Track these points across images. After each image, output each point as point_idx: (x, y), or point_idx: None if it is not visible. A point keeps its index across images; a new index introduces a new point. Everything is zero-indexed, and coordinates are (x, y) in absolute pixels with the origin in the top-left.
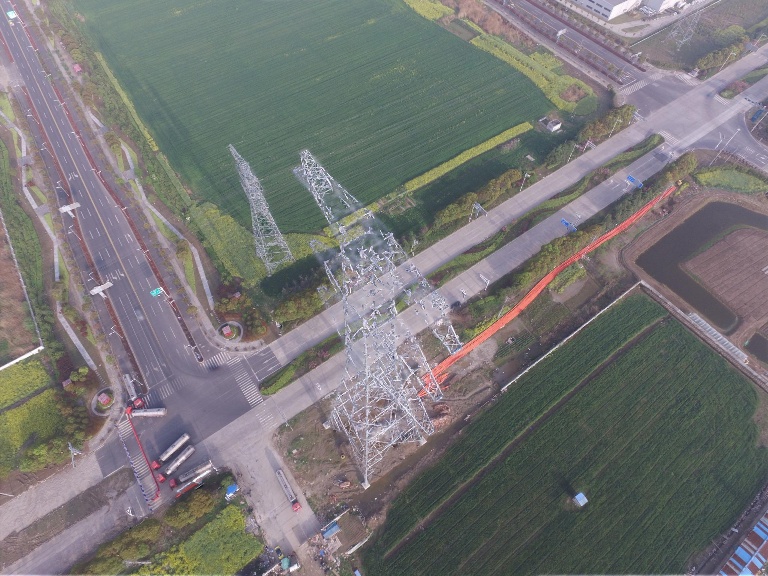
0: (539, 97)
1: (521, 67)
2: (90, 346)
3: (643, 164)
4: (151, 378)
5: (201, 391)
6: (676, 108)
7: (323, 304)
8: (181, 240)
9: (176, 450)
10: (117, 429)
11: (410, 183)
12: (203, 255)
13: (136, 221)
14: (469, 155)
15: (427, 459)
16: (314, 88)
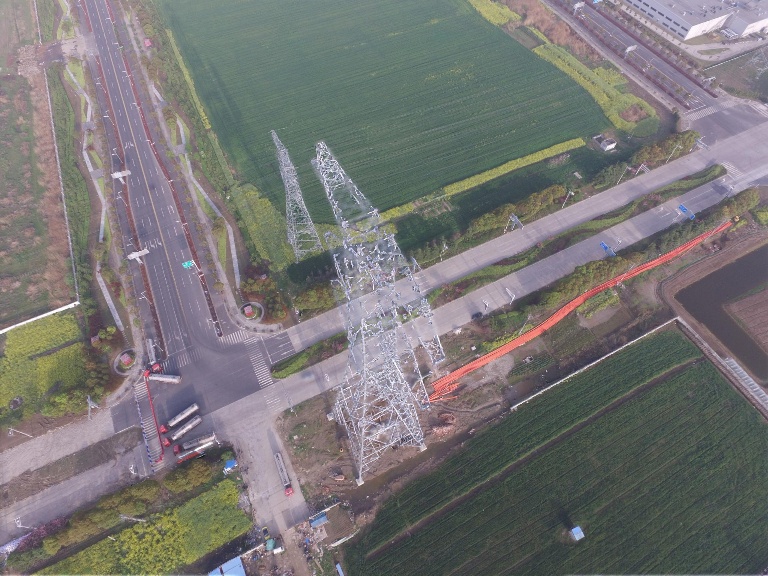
0: (597, 113)
1: (582, 81)
2: (121, 307)
3: (699, 195)
4: (172, 346)
5: (216, 365)
6: (745, 139)
7: (344, 297)
8: (218, 217)
9: (184, 418)
10: (134, 389)
11: (449, 187)
12: (237, 234)
13: (180, 194)
14: (514, 165)
15: (425, 466)
16: (368, 83)
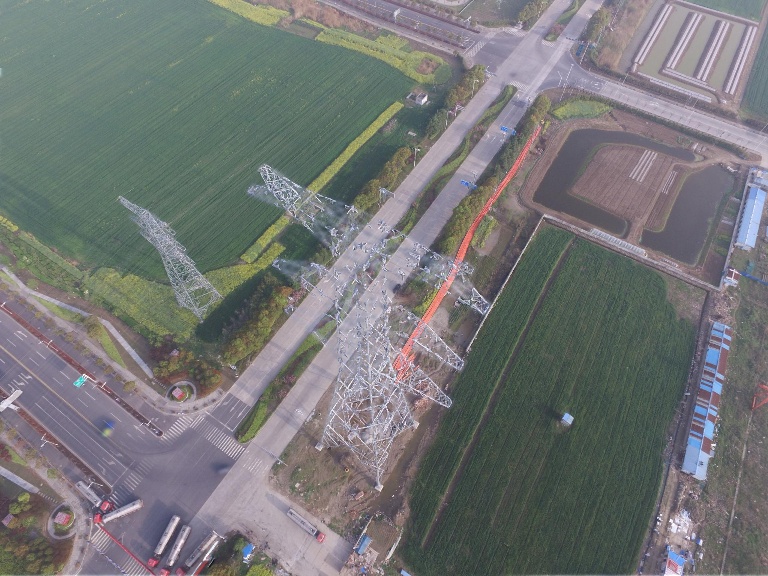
0: (399, 76)
1: (372, 52)
2: (20, 469)
3: (508, 114)
4: (110, 475)
5: (173, 466)
6: (516, 59)
7: (270, 331)
8: (87, 317)
9: (170, 537)
10: (91, 544)
11: (310, 187)
12: (118, 325)
13: (22, 314)
14: (356, 146)
15: (426, 439)
16: (175, 119)
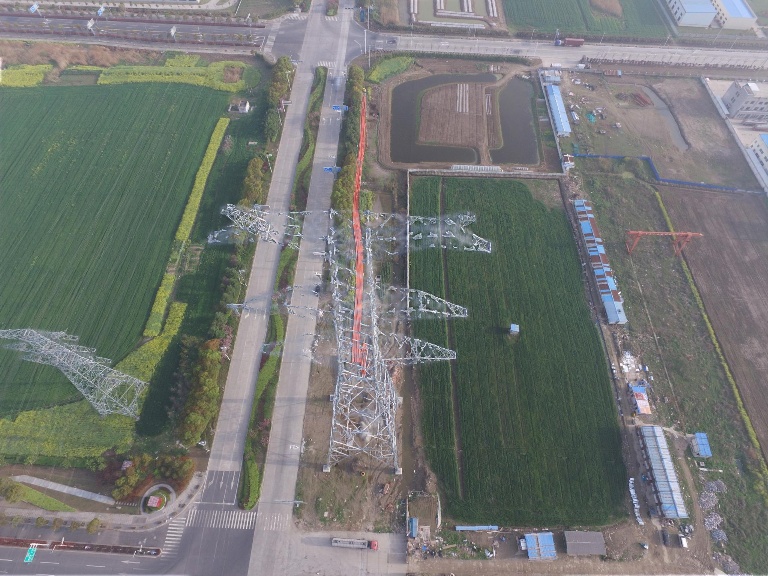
0: (209, 93)
1: (168, 78)
2: None
3: (331, 93)
4: None
5: (191, 573)
6: (311, 41)
7: (218, 390)
8: None
9: None
10: None
11: (179, 234)
12: (39, 472)
13: None
14: (203, 175)
15: (415, 408)
16: None
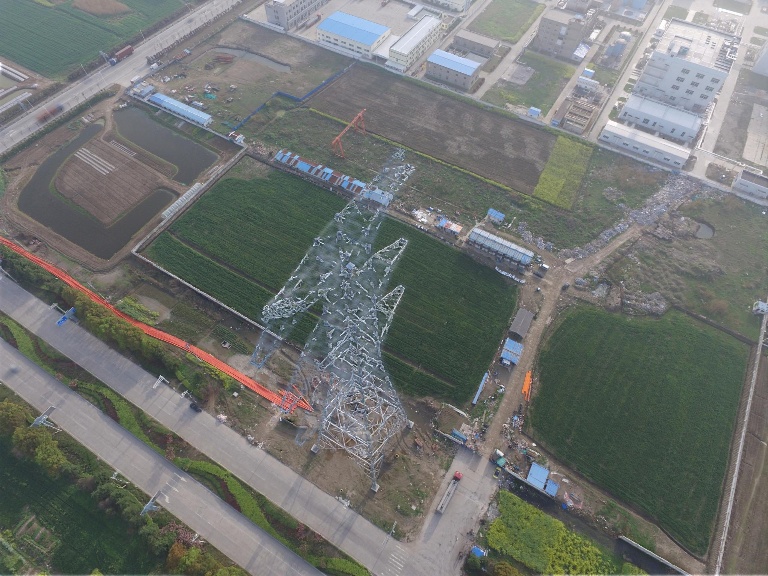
0: None
1: None
2: None
3: None
4: None
5: None
6: None
7: None
8: None
9: None
10: None
11: None
12: None
13: None
14: None
15: None
16: None
